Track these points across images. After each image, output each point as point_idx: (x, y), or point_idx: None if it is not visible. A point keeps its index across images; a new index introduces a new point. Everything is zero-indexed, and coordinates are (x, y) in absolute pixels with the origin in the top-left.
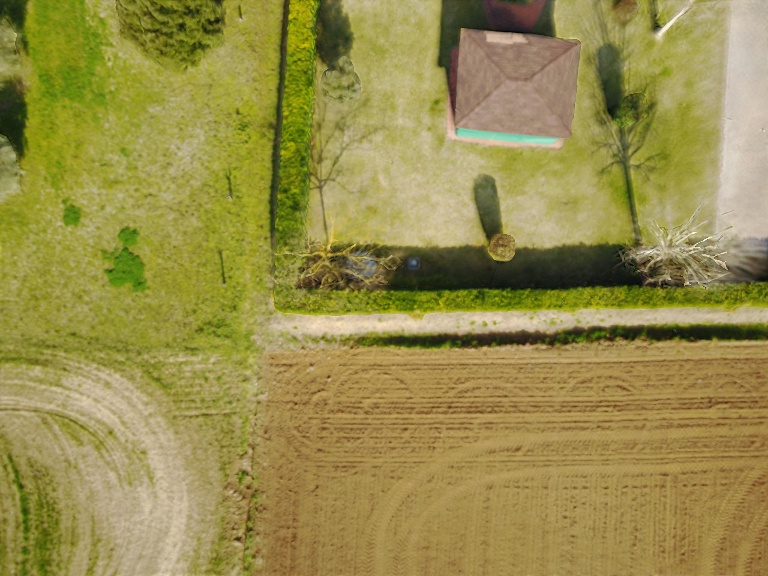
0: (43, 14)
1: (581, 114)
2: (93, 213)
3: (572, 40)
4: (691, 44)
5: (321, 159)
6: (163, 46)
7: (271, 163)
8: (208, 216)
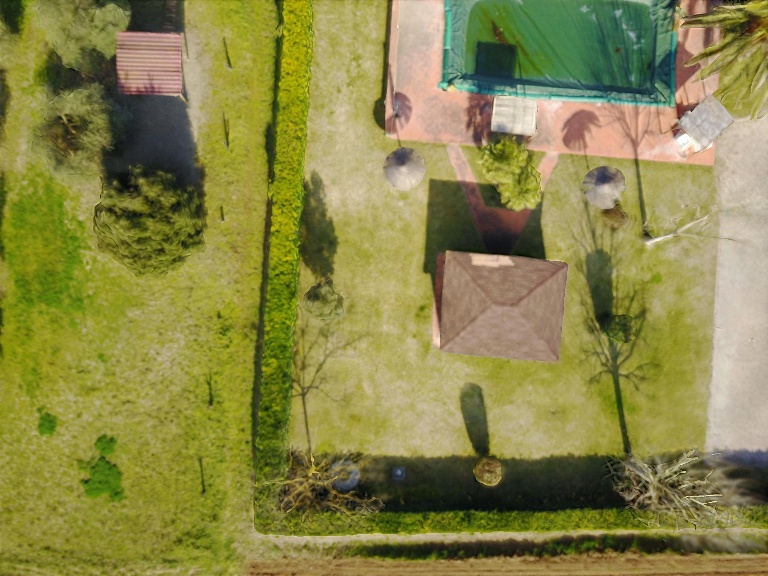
0: (20, 218)
1: (568, 322)
2: (69, 421)
3: (559, 263)
4: (679, 252)
5: (304, 366)
6: (141, 268)
7: (253, 364)
8: (188, 422)
